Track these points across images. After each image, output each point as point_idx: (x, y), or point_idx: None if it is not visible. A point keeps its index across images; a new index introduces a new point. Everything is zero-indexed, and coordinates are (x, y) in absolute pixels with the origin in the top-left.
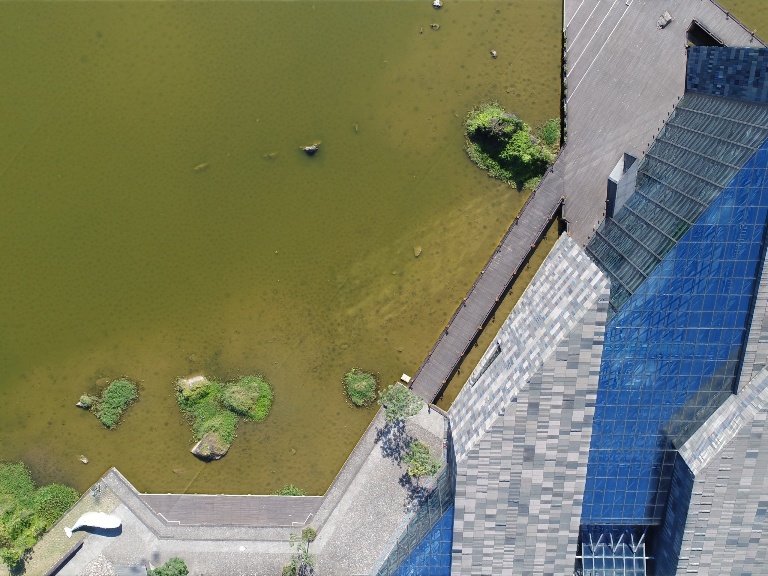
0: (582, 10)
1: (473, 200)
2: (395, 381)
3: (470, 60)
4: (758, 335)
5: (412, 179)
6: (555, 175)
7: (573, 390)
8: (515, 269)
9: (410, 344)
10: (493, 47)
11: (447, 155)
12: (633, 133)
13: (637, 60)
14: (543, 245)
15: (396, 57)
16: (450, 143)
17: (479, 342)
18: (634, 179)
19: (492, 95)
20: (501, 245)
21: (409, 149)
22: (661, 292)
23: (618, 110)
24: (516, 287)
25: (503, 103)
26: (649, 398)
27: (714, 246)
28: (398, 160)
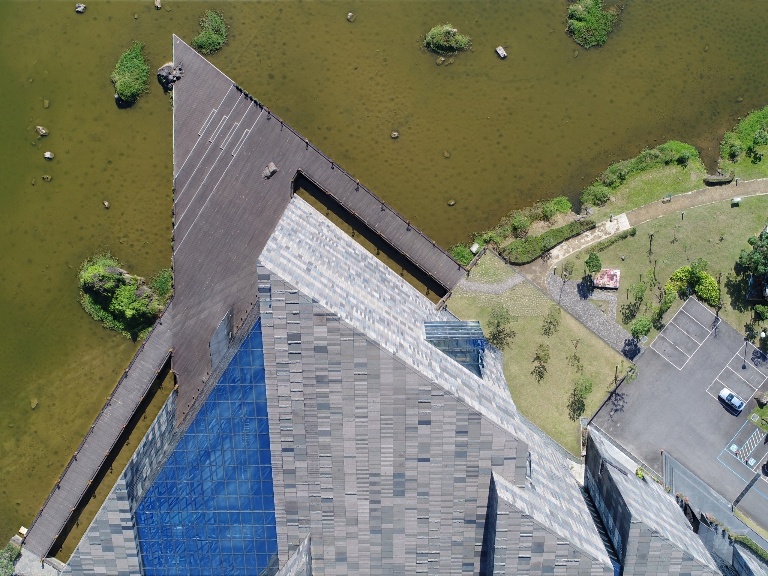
0: (190, 160)
1: (89, 351)
2: (14, 534)
3: (83, 211)
4: (284, 518)
5: (28, 331)
6: (163, 327)
7: (115, 571)
8: (125, 422)
9: (28, 496)
10: (105, 198)
11: (62, 306)
12: (241, 284)
13: (243, 211)
14: (159, 395)
15: (9, 209)
16: (65, 294)
17: (97, 493)
18: (225, 337)
19: (105, 246)
20: (111, 398)
21: (24, 301)
22: (182, 479)
23: (225, 261)
24: (133, 438)
25: (117, 254)
26: (198, 574)
27: (221, 437)
28: (13, 313)
